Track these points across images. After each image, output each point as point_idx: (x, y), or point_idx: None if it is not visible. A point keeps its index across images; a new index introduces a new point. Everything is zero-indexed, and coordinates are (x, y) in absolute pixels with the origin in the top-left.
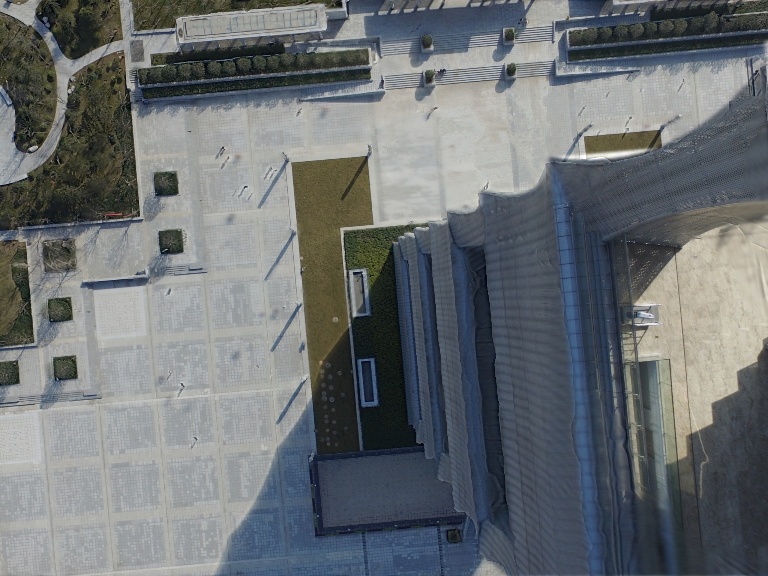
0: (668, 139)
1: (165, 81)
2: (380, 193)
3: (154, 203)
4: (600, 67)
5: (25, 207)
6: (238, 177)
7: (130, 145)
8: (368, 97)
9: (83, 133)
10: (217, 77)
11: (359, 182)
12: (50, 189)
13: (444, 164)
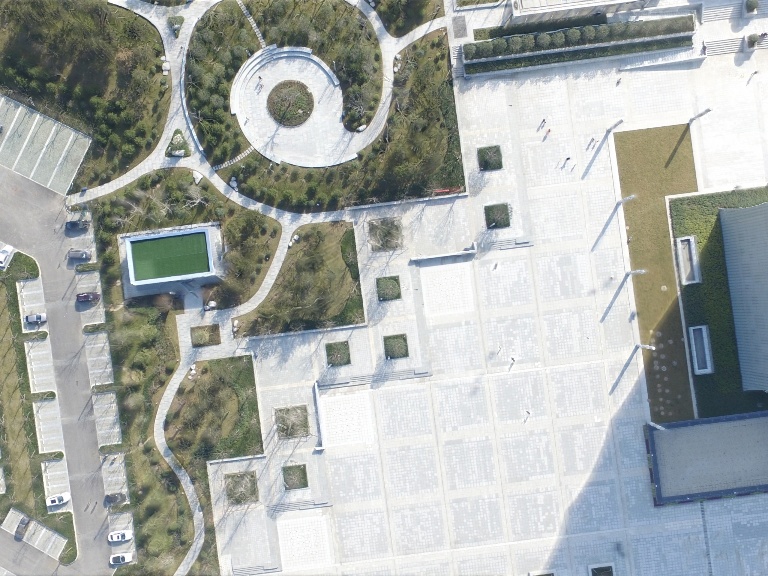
0: None
1: (491, 55)
2: (703, 160)
3: (478, 178)
4: None
5: (353, 187)
6: (560, 149)
7: (453, 121)
8: (687, 64)
9: (410, 111)
10: (542, 49)
11: (682, 149)
12: (379, 168)
13: (766, 128)
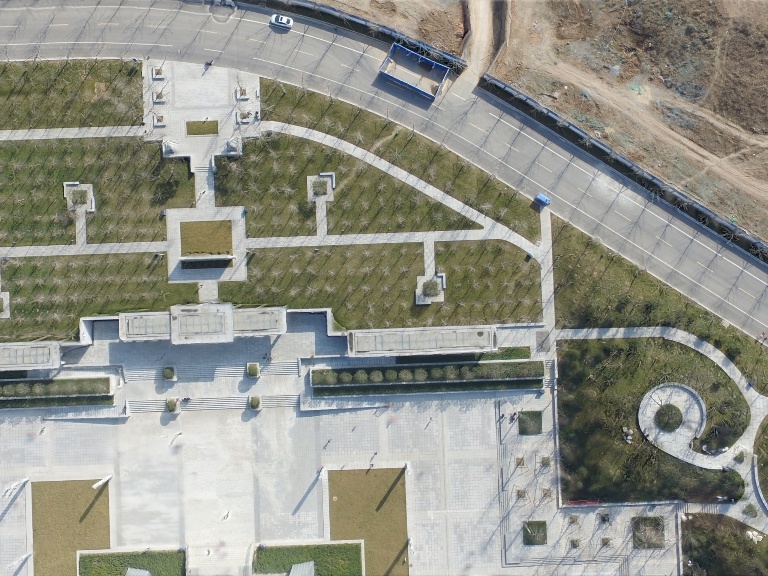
0: (412, 477)
1: None
2: (119, 517)
3: None
4: (346, 402)
5: None
6: None
7: None
8: (113, 419)
9: None
10: None
11: (98, 505)
12: None
13: (185, 491)
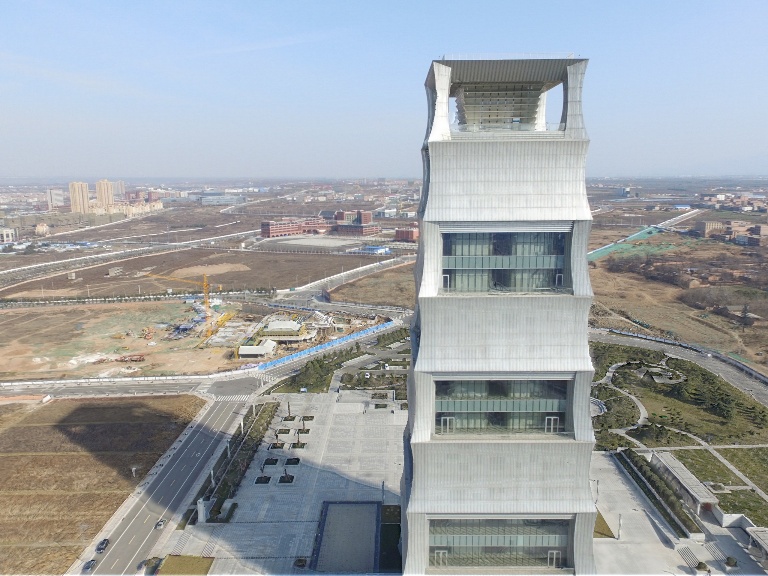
0: None
1: (628, 456)
2: None
3: None
4: None
5: None
6: None
7: None
8: (666, 541)
9: None
10: None
11: None
12: None
13: None
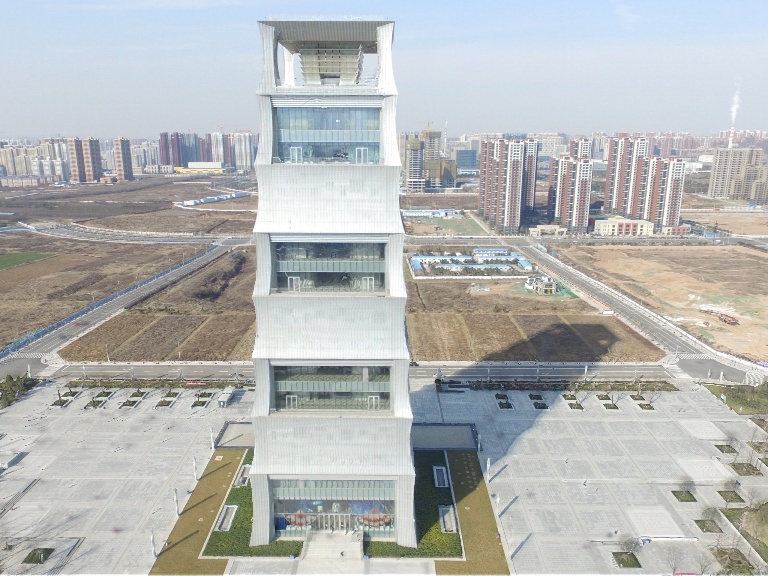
0: None
1: None
2: None
3: None
4: None
5: None
6: None
7: None
8: None
9: None
10: None
11: None
12: None
13: None
